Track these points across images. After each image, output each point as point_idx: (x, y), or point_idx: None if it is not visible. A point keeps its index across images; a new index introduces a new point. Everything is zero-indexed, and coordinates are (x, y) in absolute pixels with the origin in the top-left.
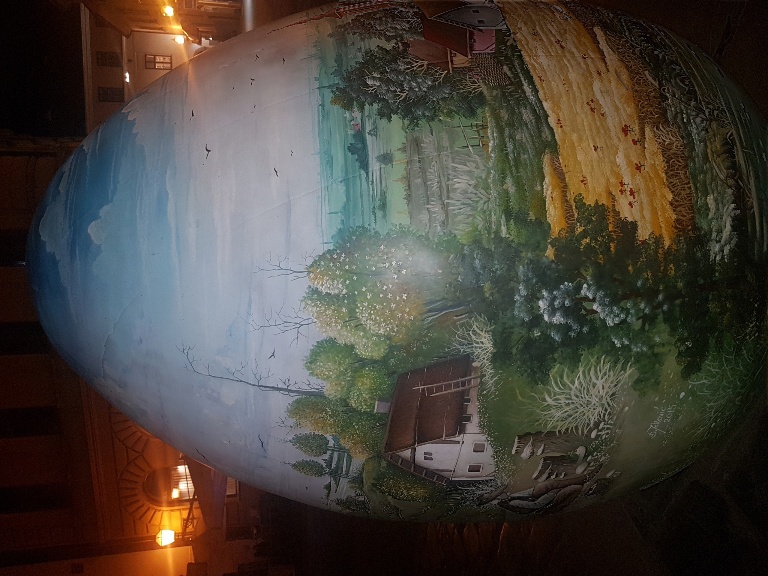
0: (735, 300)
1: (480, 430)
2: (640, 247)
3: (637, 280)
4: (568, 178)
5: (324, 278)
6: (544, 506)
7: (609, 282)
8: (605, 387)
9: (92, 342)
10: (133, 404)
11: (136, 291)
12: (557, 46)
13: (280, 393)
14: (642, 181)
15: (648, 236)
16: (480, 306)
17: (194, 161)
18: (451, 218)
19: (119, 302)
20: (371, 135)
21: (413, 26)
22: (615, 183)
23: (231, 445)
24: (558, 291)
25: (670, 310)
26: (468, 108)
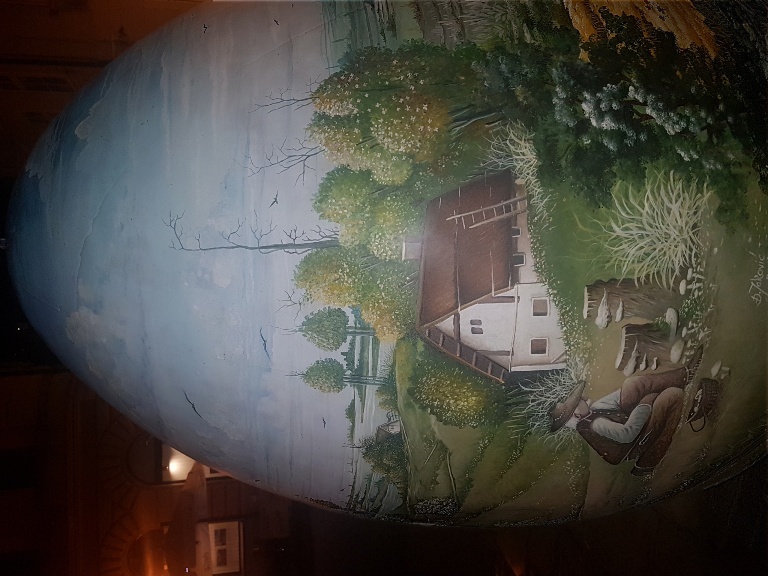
0: None
1: (538, 277)
2: (683, 55)
3: (689, 86)
4: None
5: (332, 101)
6: (639, 438)
7: (658, 85)
8: (683, 214)
9: (67, 259)
10: (110, 340)
11: (121, 170)
12: None
13: (285, 252)
14: (668, 2)
15: (689, 46)
16: (514, 111)
17: (191, 39)
18: (468, 29)
19: (101, 190)
20: None
21: None
22: (639, 1)
23: (226, 361)
24: (601, 93)
25: (736, 123)
26: None
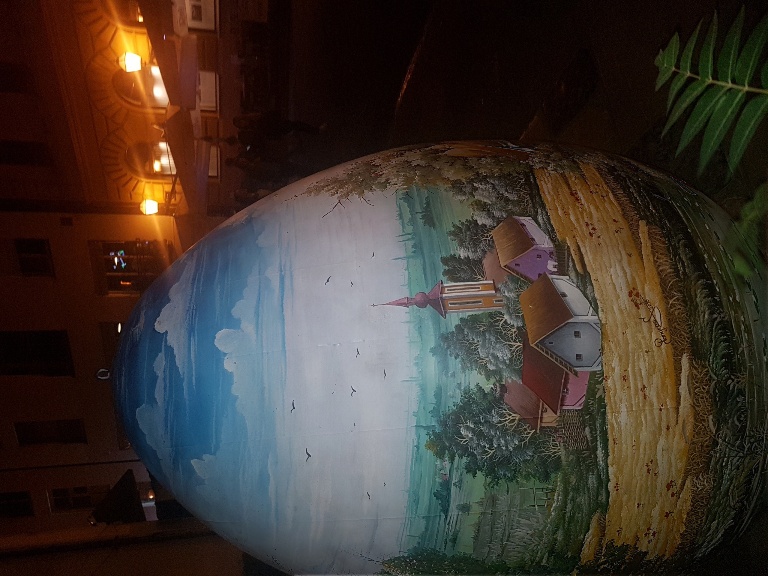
0: (701, 566)
1: None
2: (644, 564)
3: None
4: (607, 530)
5: (396, 569)
6: None
7: None
8: None
9: None
10: None
11: (236, 520)
12: (641, 396)
13: None
14: (666, 524)
15: (653, 557)
16: None
17: (295, 458)
18: (506, 553)
19: (220, 517)
20: (456, 486)
21: (514, 358)
22: (643, 530)
23: None
24: None
25: None
26: (544, 472)
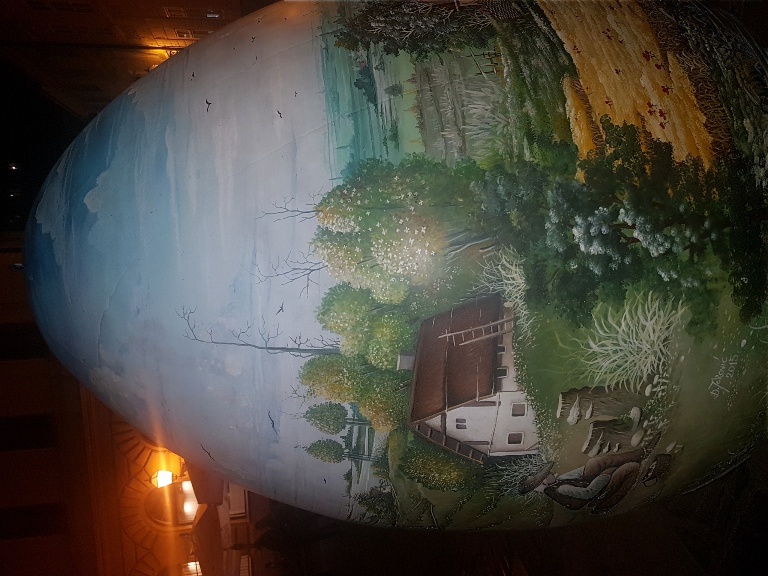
0: None
1: (518, 386)
2: (678, 169)
3: (679, 205)
4: (591, 99)
5: (334, 216)
6: (597, 495)
7: (648, 206)
8: (656, 330)
9: (87, 324)
10: (131, 395)
11: (133, 255)
12: None
13: (291, 355)
14: (671, 103)
15: (685, 158)
16: (508, 236)
17: (194, 115)
18: (469, 144)
19: (115, 271)
20: (378, 70)
21: None
22: (642, 104)
23: (238, 431)
24: (593, 217)
25: (719, 239)
26: (478, 39)
